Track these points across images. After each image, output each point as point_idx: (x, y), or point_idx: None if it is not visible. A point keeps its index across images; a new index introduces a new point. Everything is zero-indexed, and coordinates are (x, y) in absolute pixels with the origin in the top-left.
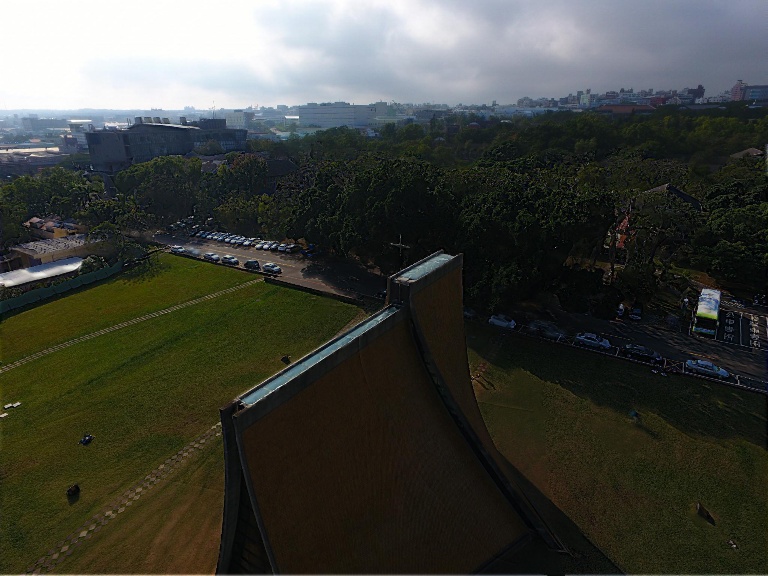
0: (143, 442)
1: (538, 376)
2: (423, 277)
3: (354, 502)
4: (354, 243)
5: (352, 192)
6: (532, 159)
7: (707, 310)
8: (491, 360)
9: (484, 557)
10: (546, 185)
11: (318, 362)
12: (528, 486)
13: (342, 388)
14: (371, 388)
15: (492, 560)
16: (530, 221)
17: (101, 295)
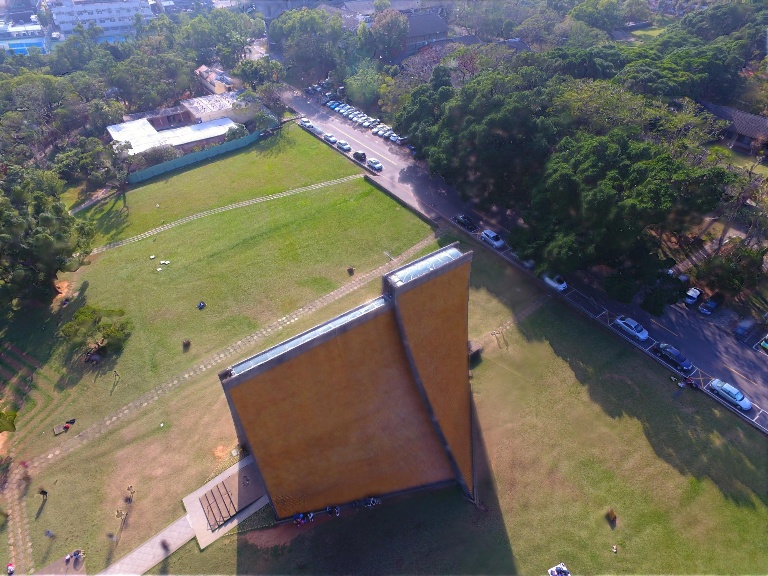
0: (233, 319)
1: (554, 349)
2: (411, 281)
3: (317, 431)
4: (439, 167)
5: (454, 106)
6: (734, 46)
7: None
8: (521, 319)
9: (412, 484)
10: (681, 127)
11: (294, 348)
12: (480, 444)
13: (317, 361)
14: (346, 360)
15: (418, 487)
16: (606, 194)
17: (237, 166)
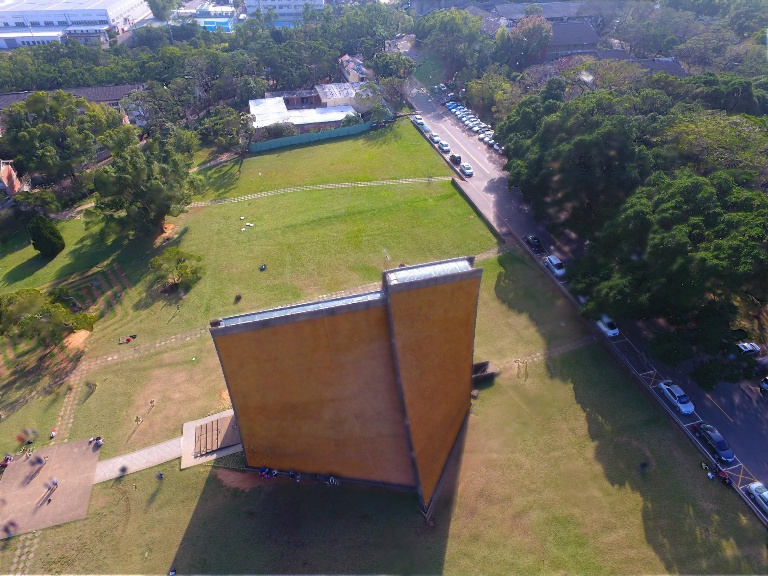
0: (283, 285)
1: (576, 394)
2: (406, 282)
3: (293, 398)
4: (517, 181)
5: (551, 121)
6: None
7: None
8: (553, 355)
9: (374, 477)
10: None
11: (279, 316)
12: (456, 463)
13: (303, 335)
14: (332, 342)
15: (378, 483)
16: (676, 241)
17: (342, 151)
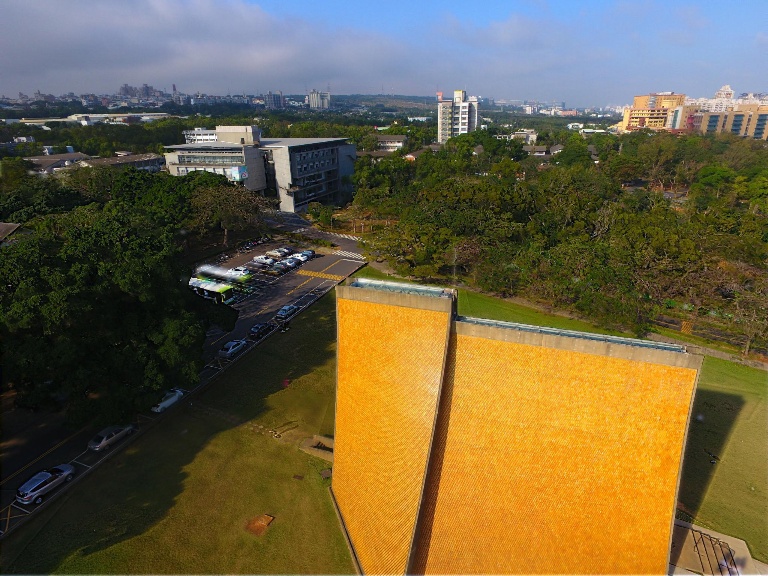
0: None
1: (279, 390)
2: None
3: None
4: None
5: None
6: None
7: (217, 286)
8: (243, 420)
9: None
10: None
11: None
12: None
13: None
14: None
15: None
16: None
17: None
